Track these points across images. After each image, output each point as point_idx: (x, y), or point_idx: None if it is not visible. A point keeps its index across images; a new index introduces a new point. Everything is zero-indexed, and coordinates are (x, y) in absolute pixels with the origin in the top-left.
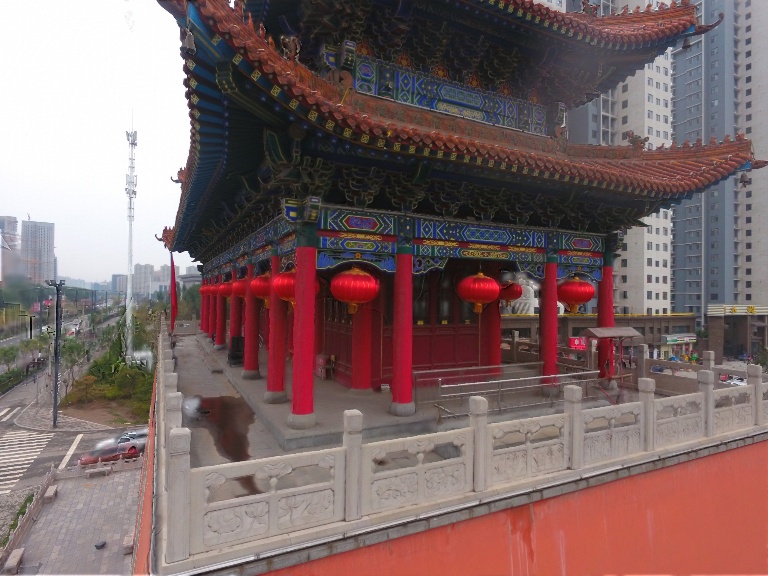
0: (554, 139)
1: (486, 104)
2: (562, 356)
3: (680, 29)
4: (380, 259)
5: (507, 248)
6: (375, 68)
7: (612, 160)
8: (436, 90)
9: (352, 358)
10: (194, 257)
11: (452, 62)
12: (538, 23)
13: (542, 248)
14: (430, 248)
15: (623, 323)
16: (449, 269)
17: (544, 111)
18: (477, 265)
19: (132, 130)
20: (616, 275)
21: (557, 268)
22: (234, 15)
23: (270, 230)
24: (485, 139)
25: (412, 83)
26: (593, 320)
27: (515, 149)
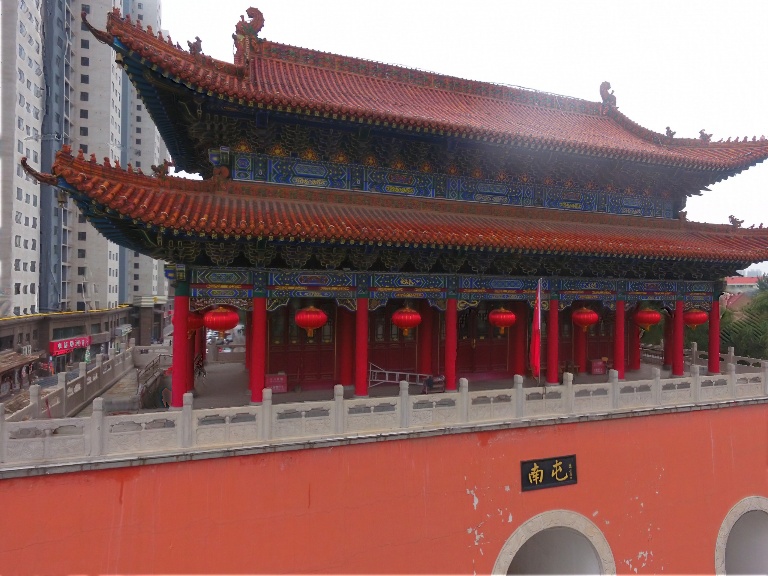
0: None
1: None
2: (38, 366)
3: None
4: None
5: None
6: None
7: None
8: None
9: (637, 353)
10: (167, 246)
11: None
12: None
13: None
14: None
15: (97, 319)
16: None
17: None
18: None
19: None
20: (85, 267)
21: None
22: None
23: (673, 285)
24: None
25: None
26: (73, 318)
27: None
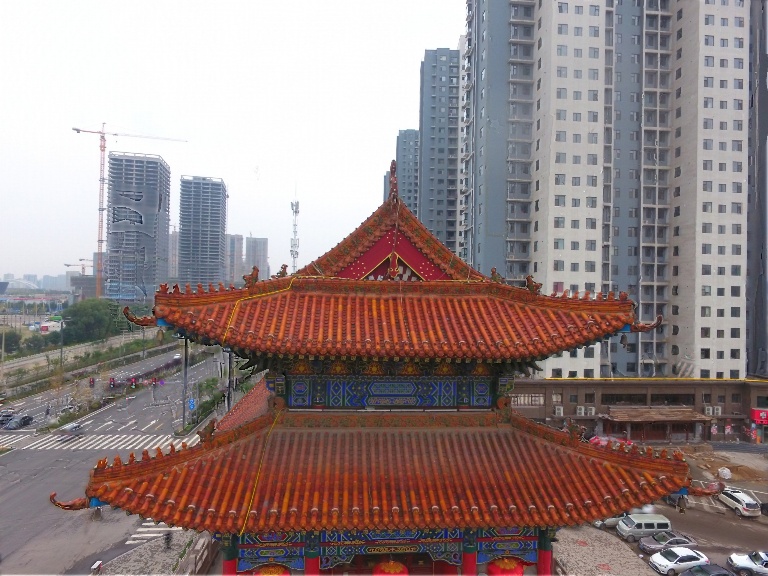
0: (496, 411)
1: (419, 389)
2: (742, 429)
3: (610, 331)
4: (291, 560)
5: (418, 540)
6: (308, 383)
7: (550, 444)
8: (366, 388)
9: None
10: None
11: (382, 362)
12: (429, 361)
13: (457, 538)
14: (336, 549)
15: None
16: (358, 561)
17: (488, 382)
18: (387, 555)
19: (296, 201)
20: None
21: (478, 554)
22: (140, 464)
23: None
24: (413, 426)
25: (343, 388)
26: None
27: (374, 508)
